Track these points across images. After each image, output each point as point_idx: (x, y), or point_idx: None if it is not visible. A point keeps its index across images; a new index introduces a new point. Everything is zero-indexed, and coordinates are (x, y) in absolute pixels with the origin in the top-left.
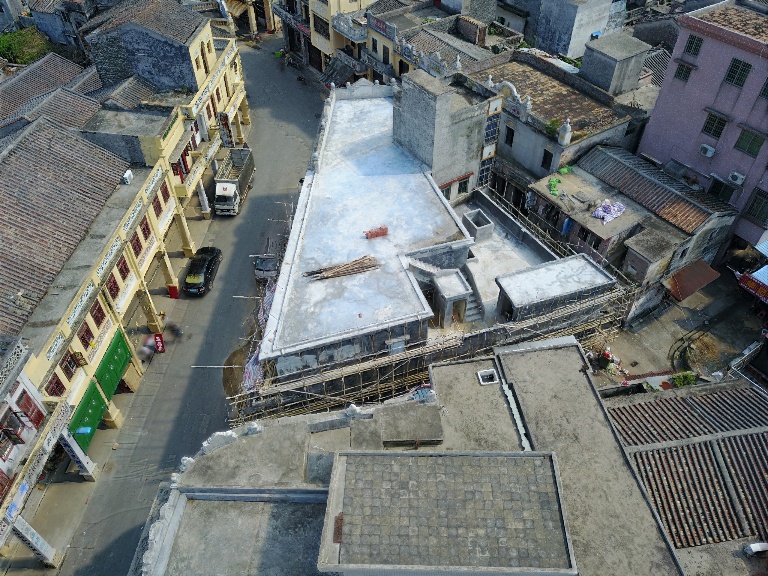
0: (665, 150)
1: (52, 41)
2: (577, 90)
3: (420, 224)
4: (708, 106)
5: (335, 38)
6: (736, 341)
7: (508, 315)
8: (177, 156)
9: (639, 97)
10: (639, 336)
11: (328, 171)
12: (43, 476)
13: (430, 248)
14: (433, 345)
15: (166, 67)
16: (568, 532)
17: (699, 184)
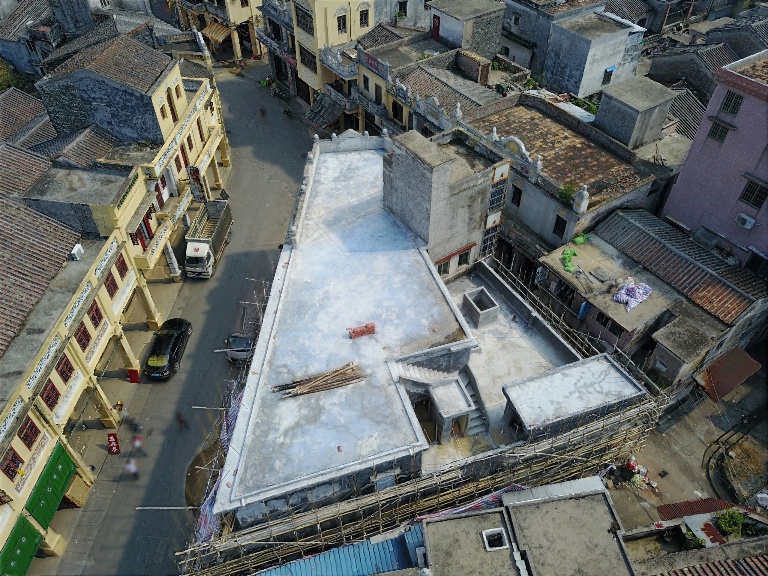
0: (695, 215)
1: (18, 70)
2: (593, 142)
3: (413, 318)
4: (748, 172)
5: (323, 72)
6: None
7: (517, 426)
8: (136, 224)
9: (663, 150)
10: (667, 437)
11: (308, 246)
12: None
13: (425, 352)
14: (428, 477)
15: (127, 117)
16: None
17: (734, 256)
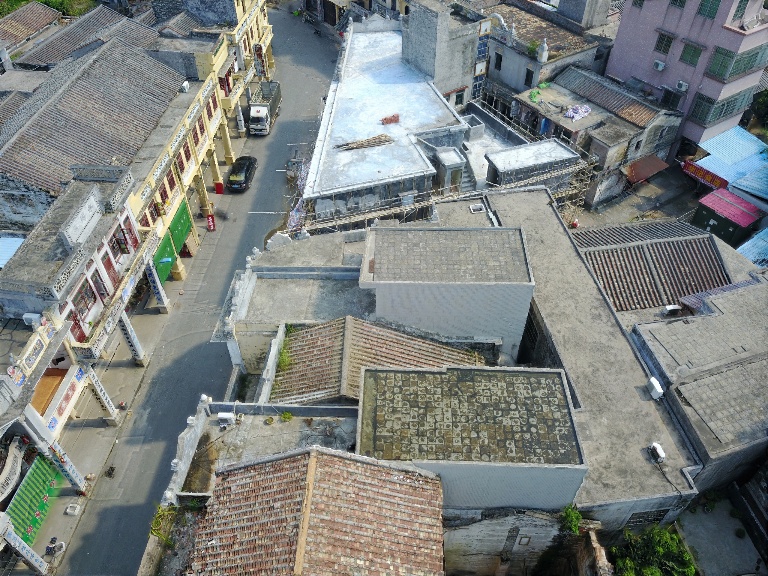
0: (626, 70)
1: None
2: (555, 24)
3: (425, 115)
4: (658, 27)
5: None
6: (680, 216)
7: None
8: (224, 72)
9: (607, 30)
10: (603, 215)
11: (349, 81)
12: (127, 309)
13: (433, 130)
14: None
15: (212, 3)
16: (530, 265)
17: (654, 96)
